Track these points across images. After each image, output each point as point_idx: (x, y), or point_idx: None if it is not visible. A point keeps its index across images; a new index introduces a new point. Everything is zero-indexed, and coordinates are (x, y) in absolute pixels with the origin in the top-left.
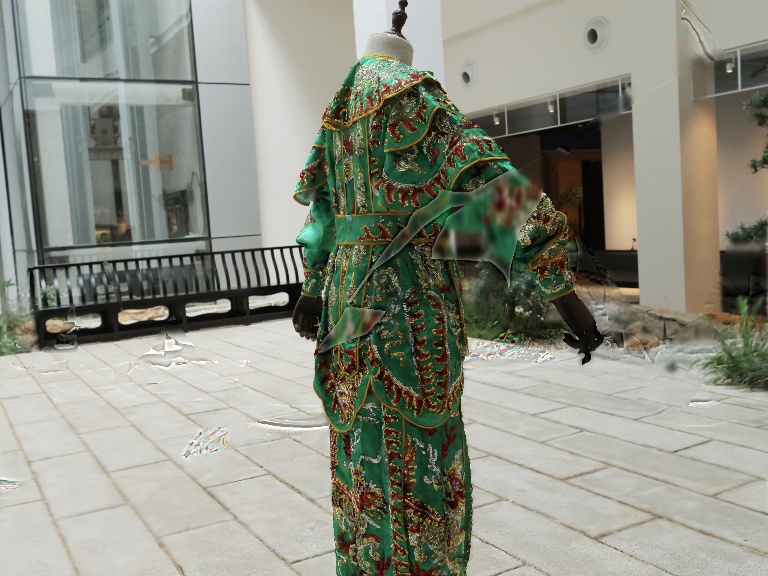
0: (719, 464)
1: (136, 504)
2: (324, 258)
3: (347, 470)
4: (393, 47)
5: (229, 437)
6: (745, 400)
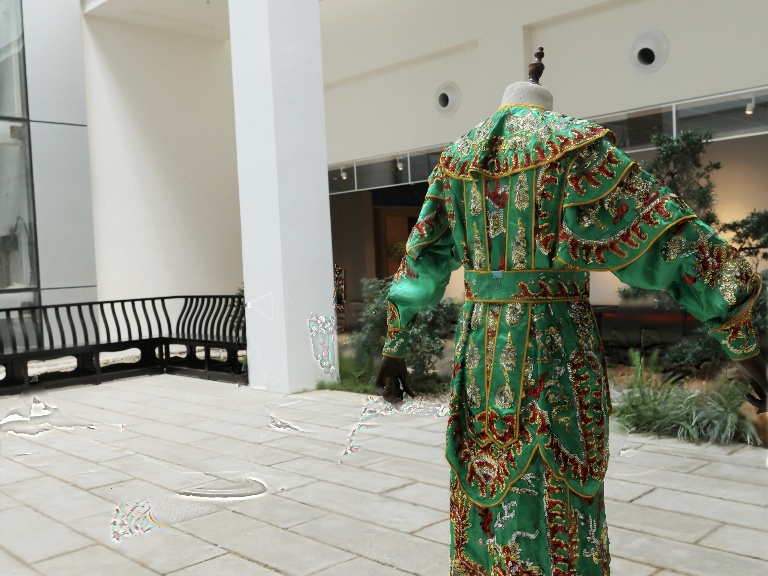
0: (680, 511)
1: None
2: (415, 316)
3: (483, 548)
4: (543, 98)
5: (156, 513)
6: (659, 447)
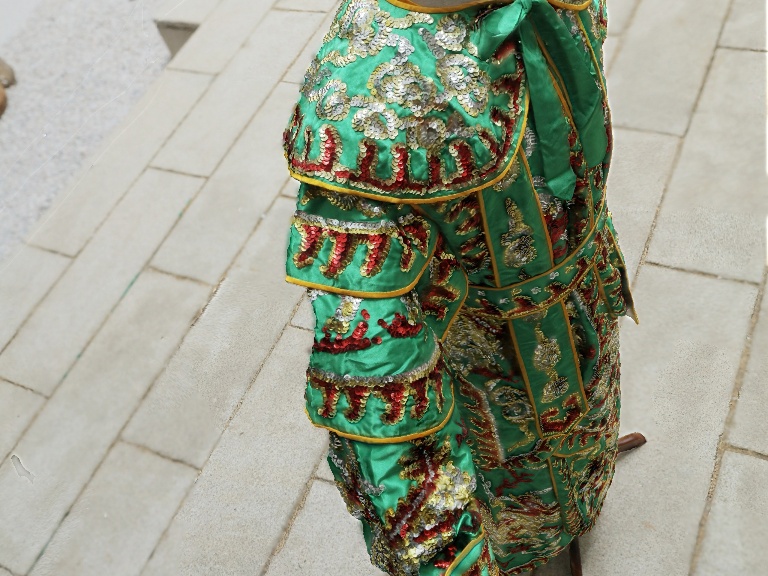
0: None
1: (627, 41)
2: None
3: None
4: None
5: None
6: None
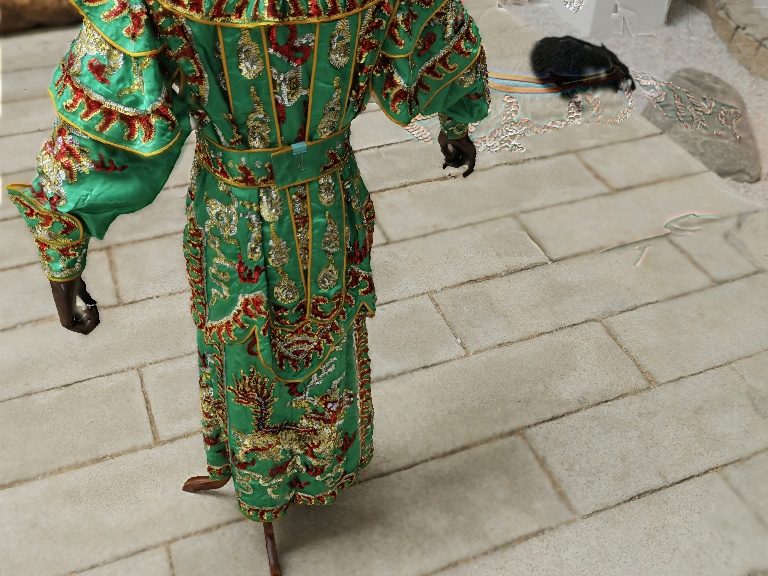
0: (29, 167)
1: None
2: None
3: (289, 408)
4: None
5: None
6: None
